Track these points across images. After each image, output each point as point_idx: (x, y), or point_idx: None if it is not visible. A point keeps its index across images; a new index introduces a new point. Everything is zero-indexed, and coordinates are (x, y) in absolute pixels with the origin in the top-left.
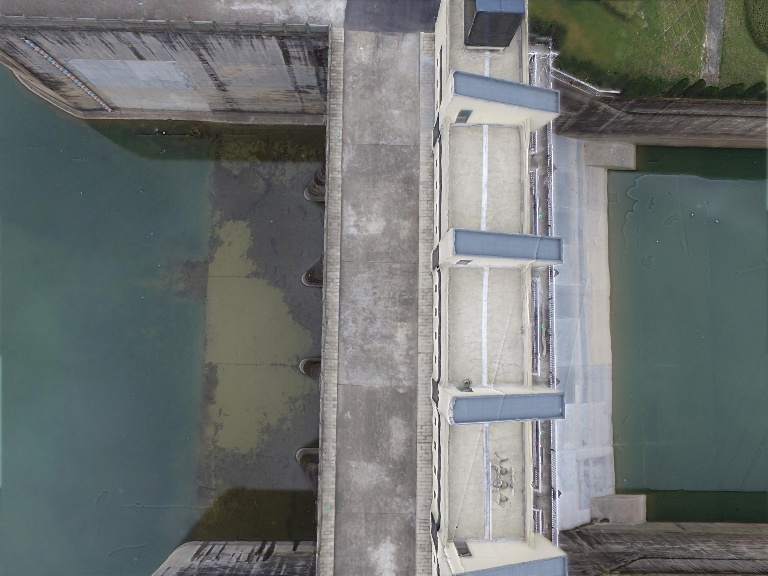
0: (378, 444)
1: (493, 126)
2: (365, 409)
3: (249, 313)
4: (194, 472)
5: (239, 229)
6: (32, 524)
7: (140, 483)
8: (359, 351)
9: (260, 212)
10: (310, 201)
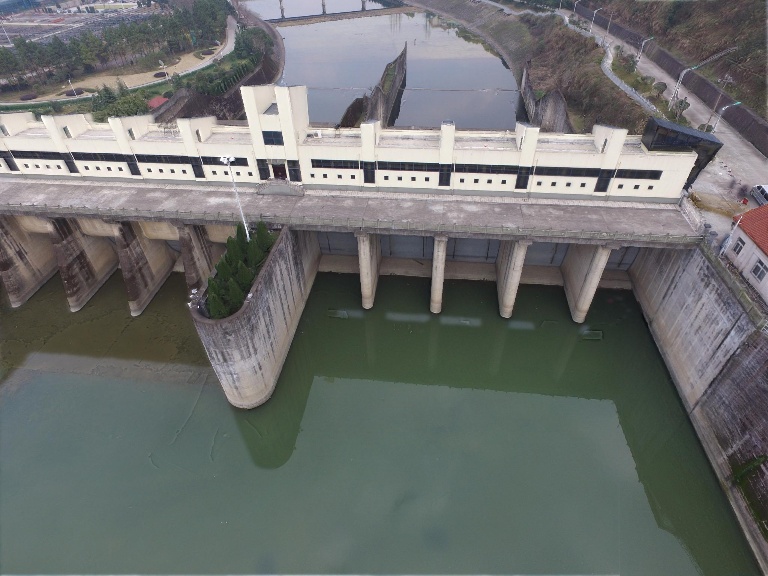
0: (156, 200)
1: (21, 132)
2: (134, 203)
3: (73, 344)
4: (173, 387)
5: (4, 347)
6: (147, 542)
7: (159, 427)
8: (102, 204)
9: (3, 334)
10: (22, 305)
